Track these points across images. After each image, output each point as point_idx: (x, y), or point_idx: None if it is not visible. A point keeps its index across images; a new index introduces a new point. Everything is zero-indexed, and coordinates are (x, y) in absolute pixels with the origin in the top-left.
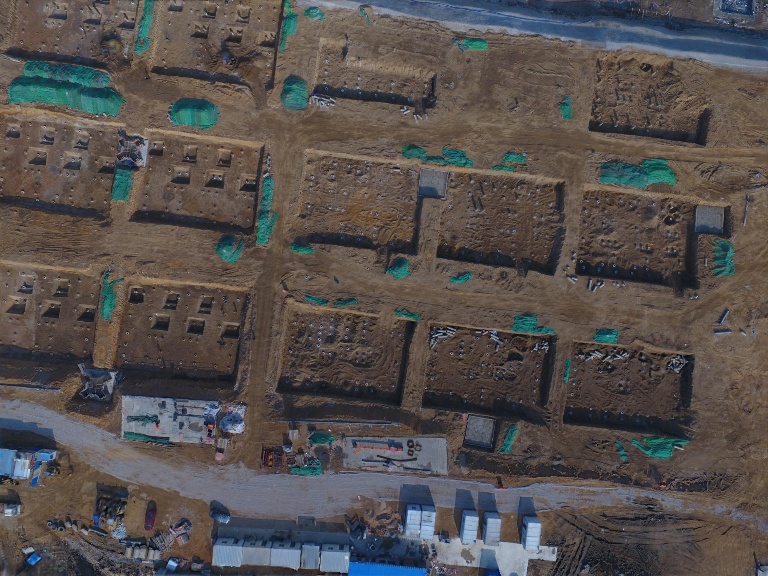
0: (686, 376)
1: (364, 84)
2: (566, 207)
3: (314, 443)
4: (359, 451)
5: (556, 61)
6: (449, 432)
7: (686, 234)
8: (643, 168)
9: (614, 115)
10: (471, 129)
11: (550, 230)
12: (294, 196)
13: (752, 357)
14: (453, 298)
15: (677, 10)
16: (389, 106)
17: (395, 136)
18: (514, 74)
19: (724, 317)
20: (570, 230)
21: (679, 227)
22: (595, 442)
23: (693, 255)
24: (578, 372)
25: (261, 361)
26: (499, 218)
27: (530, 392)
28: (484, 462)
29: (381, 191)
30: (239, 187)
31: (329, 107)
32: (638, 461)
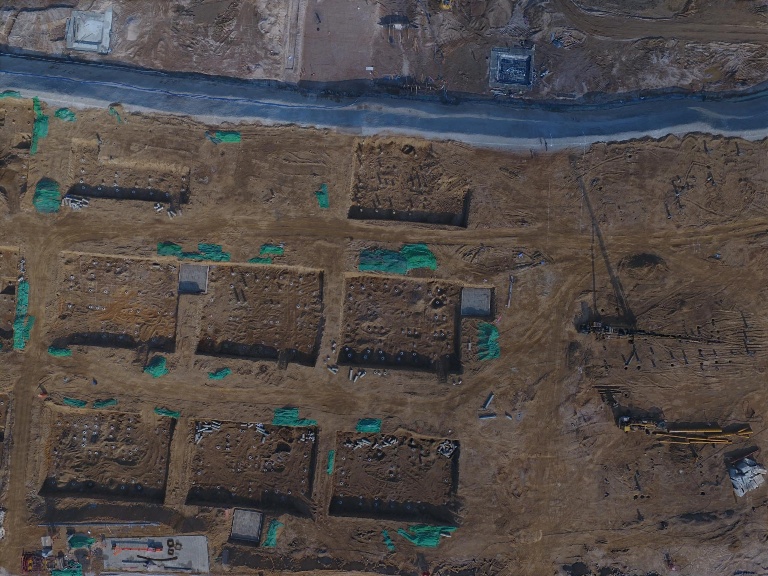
0: (455, 461)
1: (122, 181)
2: (325, 297)
3: (71, 547)
4: (119, 552)
5: (311, 149)
6: (211, 529)
7: (454, 317)
8: (402, 254)
9: (376, 199)
10: (226, 223)
11: (314, 319)
12: (50, 299)
13: (519, 441)
14: (213, 394)
15: (452, 84)
16: (143, 204)
17: (150, 233)
18: (269, 165)
19: (489, 402)
20: (330, 320)
21: (447, 310)
22: (360, 533)
23: (458, 339)
24: (347, 461)
25: (20, 466)
26: (262, 309)
27: (299, 483)
28: (248, 557)
29: (141, 288)
30: (0, 290)
31: (82, 208)
32: (405, 550)
